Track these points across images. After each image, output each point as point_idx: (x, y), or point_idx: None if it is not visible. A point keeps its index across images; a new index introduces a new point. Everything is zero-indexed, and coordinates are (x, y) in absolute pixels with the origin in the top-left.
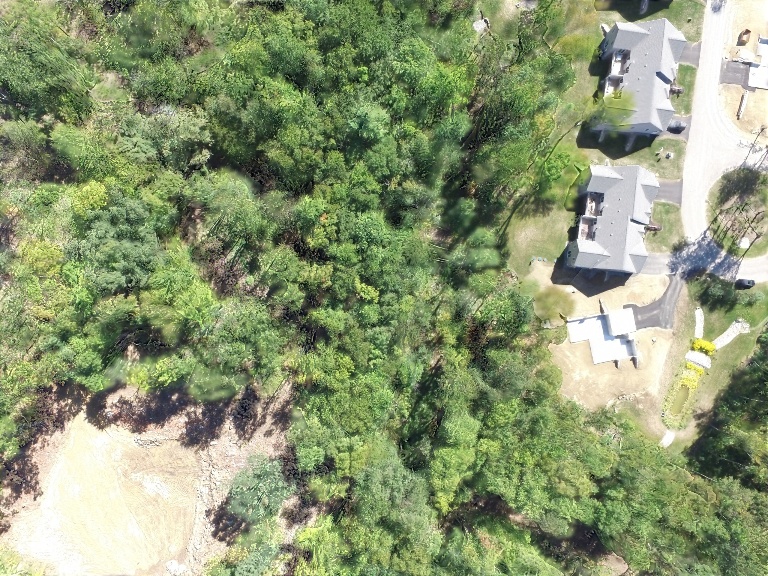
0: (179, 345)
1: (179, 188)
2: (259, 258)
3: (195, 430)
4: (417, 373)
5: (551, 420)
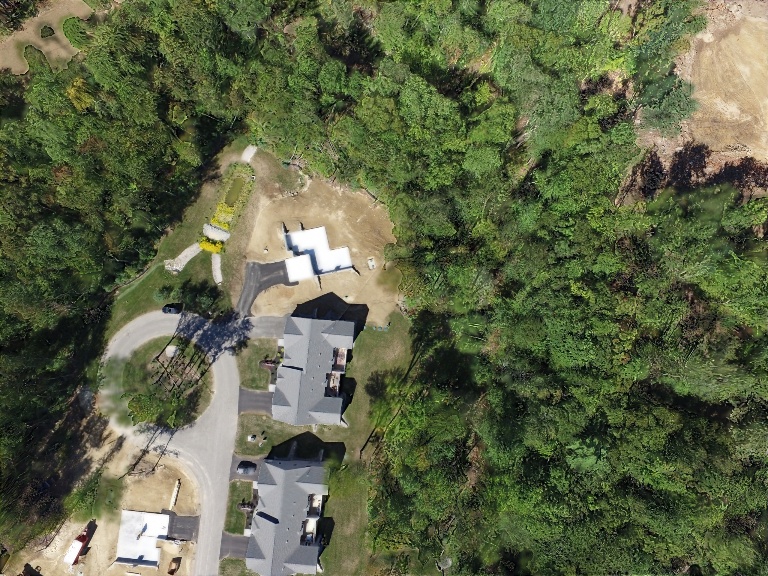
0: (717, 239)
1: (761, 384)
2: (649, 322)
3: (697, 160)
4: (494, 215)
5: (398, 170)
